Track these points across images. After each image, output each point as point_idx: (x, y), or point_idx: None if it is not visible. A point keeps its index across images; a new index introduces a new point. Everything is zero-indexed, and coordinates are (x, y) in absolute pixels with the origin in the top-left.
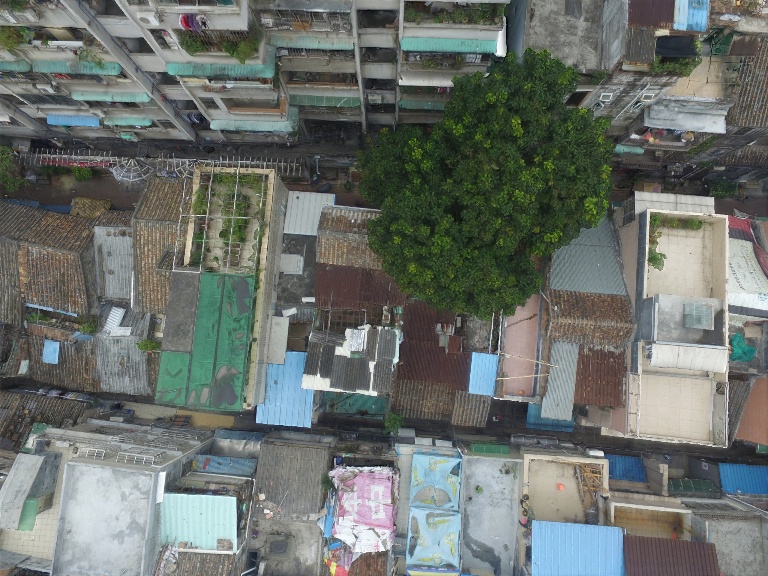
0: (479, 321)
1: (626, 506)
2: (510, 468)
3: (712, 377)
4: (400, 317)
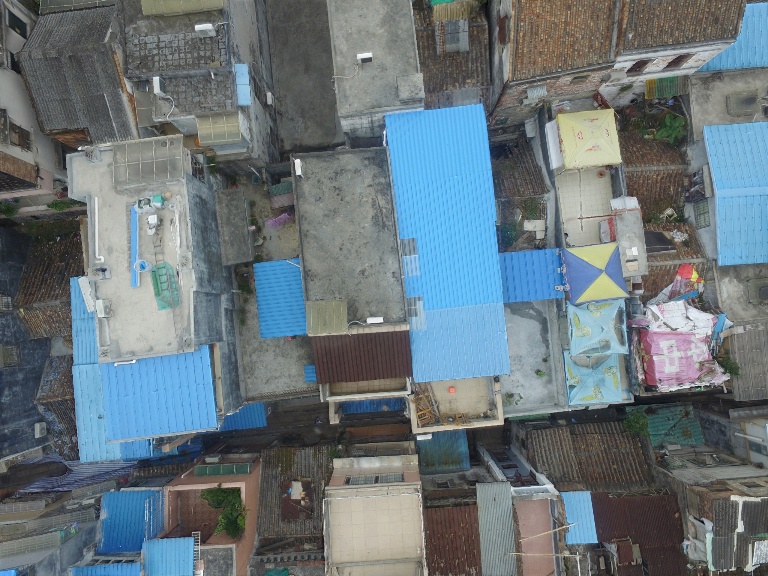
0: (581, 570)
1: (395, 393)
2: (508, 399)
3: (333, 568)
4: (694, 574)
